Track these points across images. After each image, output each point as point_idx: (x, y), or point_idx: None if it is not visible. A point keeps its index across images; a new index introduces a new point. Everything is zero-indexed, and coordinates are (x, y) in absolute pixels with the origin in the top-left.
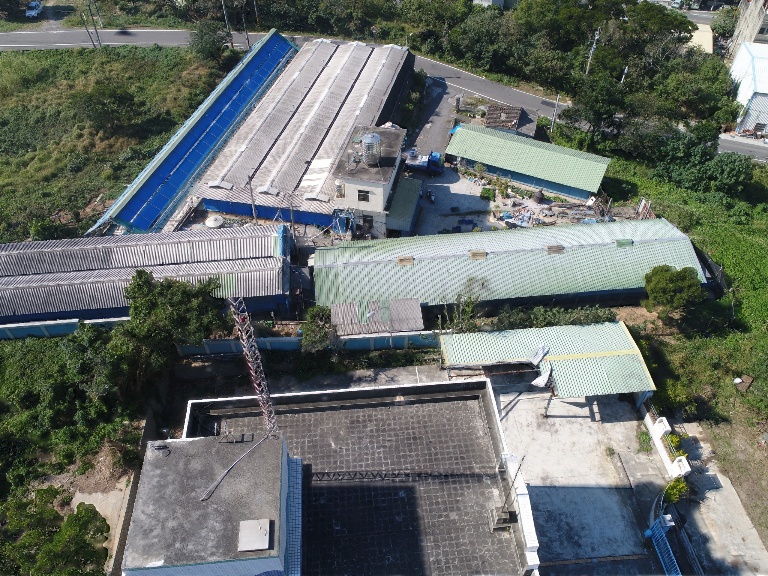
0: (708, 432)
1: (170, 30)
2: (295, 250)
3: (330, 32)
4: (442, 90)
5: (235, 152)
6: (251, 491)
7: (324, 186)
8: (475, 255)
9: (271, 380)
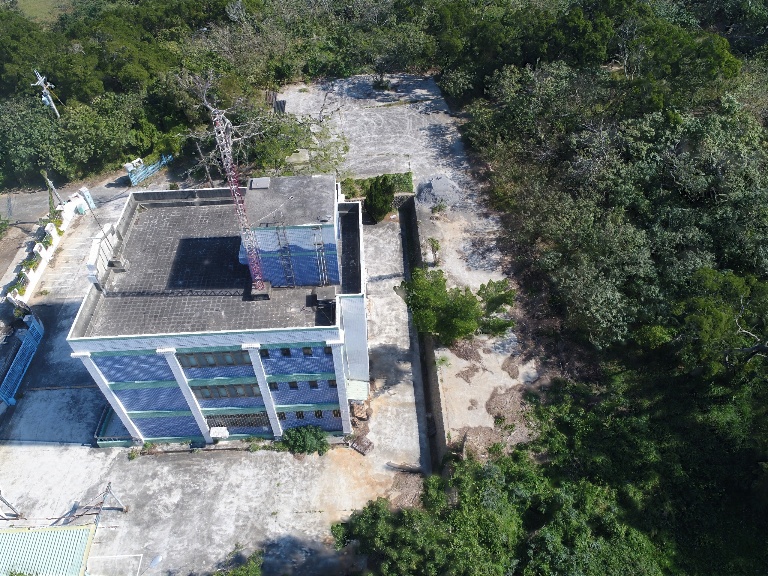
0: None
1: None
2: None
3: None
4: None
5: None
6: (262, 201)
7: None
8: None
9: None
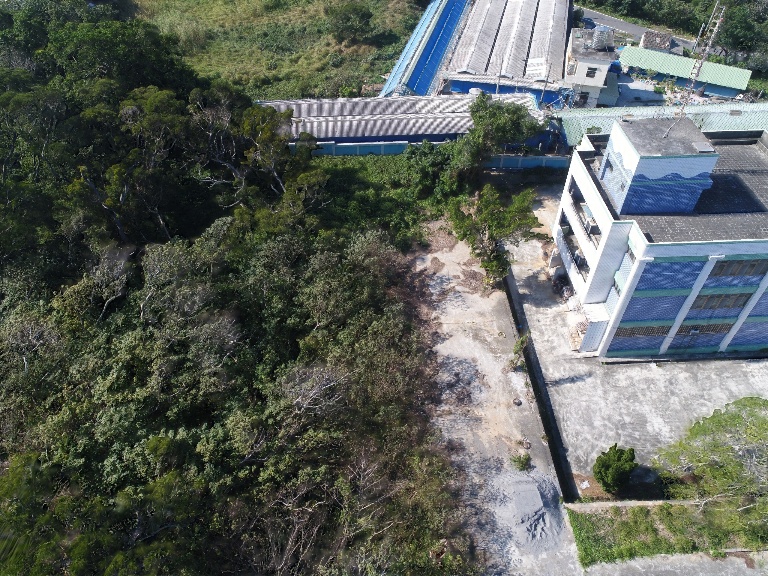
0: None
1: None
2: None
3: None
4: (592, 27)
5: (467, 52)
6: (688, 135)
7: (547, 73)
8: None
9: (547, 186)
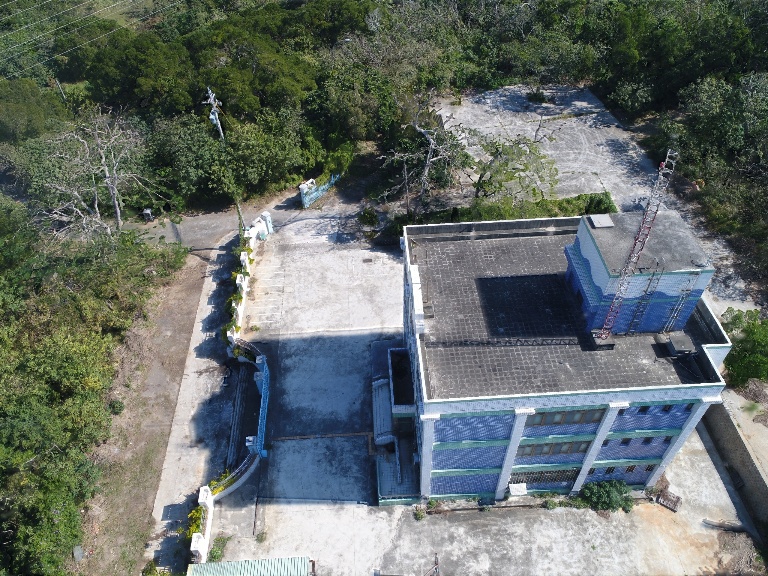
0: (135, 571)
1: None
2: None
3: None
4: None
5: None
6: (616, 242)
7: None
8: None
9: None
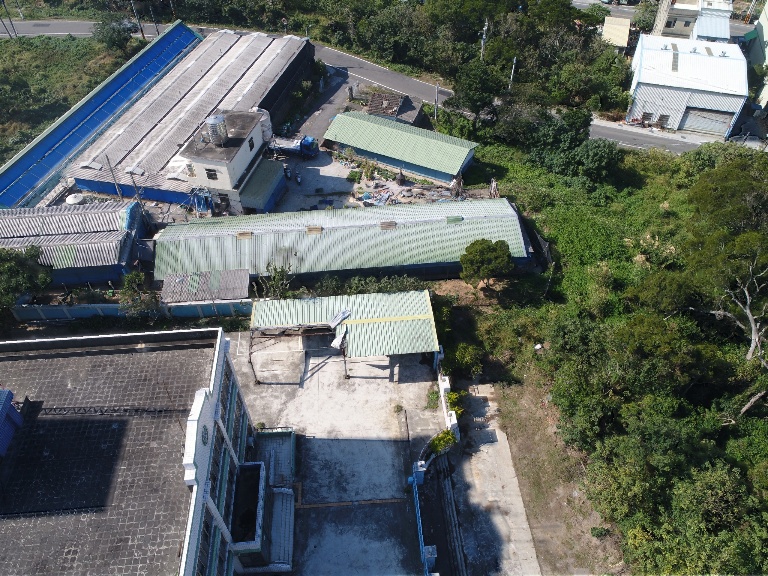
0: (499, 393)
1: (88, 22)
2: (148, 226)
3: (244, 24)
4: (342, 80)
5: (113, 135)
6: None
7: None
8: (311, 230)
9: None
